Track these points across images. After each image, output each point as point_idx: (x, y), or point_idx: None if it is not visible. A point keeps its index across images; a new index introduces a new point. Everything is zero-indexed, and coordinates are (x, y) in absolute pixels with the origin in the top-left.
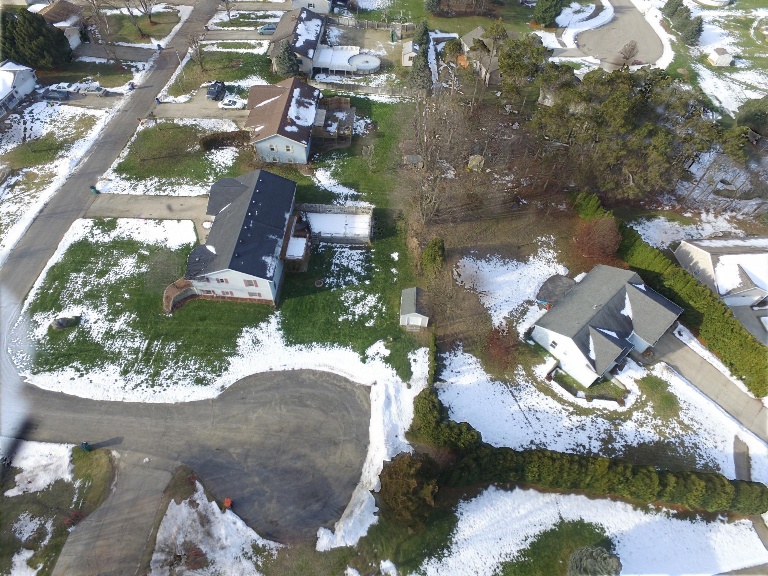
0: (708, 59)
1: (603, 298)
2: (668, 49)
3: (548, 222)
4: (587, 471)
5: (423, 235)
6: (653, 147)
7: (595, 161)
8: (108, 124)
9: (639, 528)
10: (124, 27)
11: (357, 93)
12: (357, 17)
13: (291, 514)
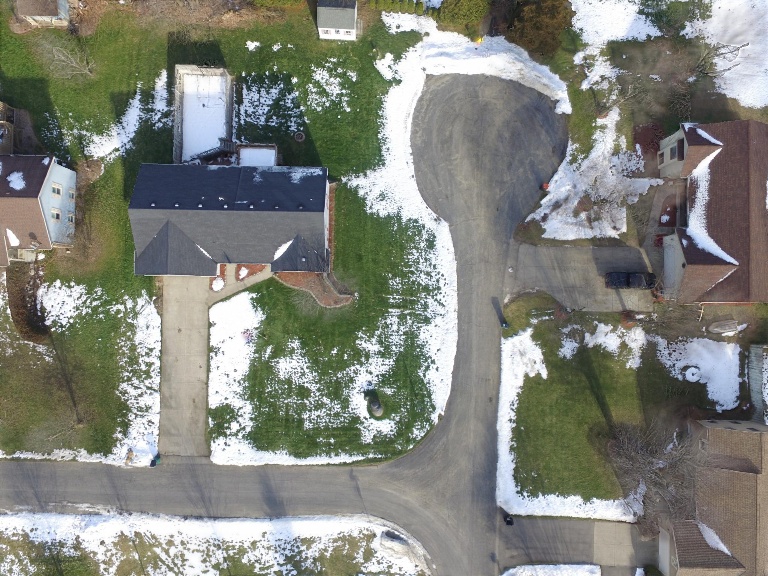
0: None
1: None
2: None
3: None
4: None
5: (216, 7)
6: None
7: None
8: None
9: None
10: None
11: None
12: None
13: (547, 137)
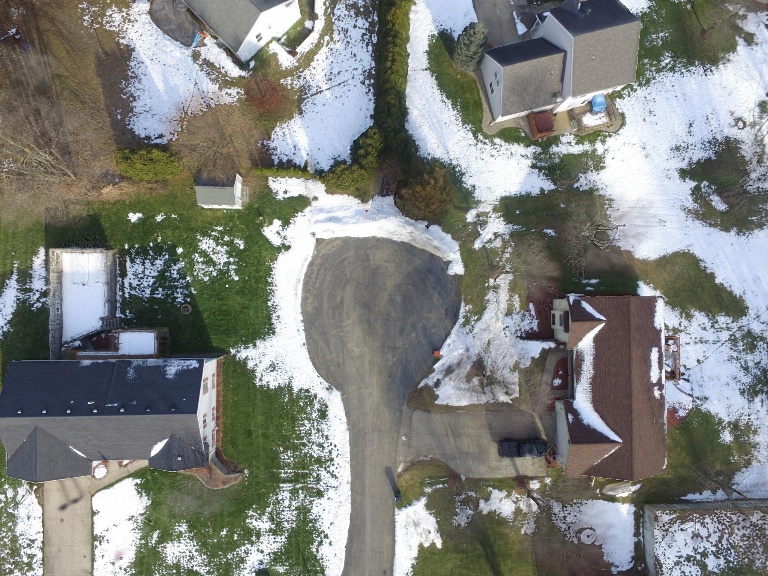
0: None
1: None
2: None
3: (53, 5)
4: (399, 33)
5: (95, 180)
6: None
7: None
8: None
9: (430, 5)
10: None
11: None
12: None
13: (439, 299)
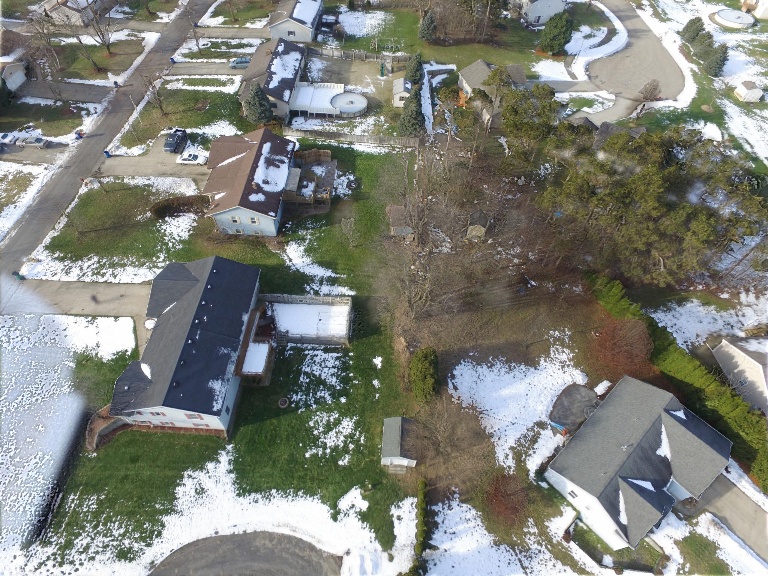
0: (735, 93)
1: (634, 433)
2: (690, 81)
3: (561, 310)
4: None
5: (412, 333)
6: (692, 233)
7: (619, 244)
8: (46, 185)
9: None
10: (79, 59)
11: (340, 141)
12: (343, 46)
13: None
